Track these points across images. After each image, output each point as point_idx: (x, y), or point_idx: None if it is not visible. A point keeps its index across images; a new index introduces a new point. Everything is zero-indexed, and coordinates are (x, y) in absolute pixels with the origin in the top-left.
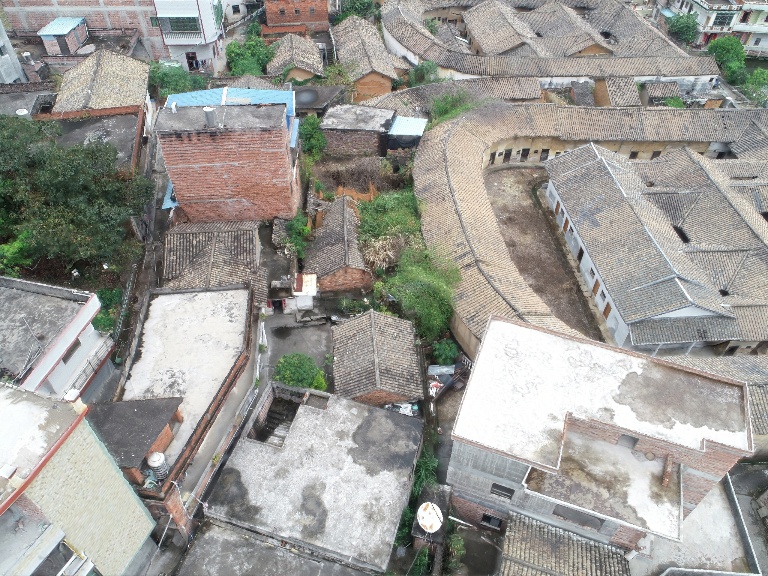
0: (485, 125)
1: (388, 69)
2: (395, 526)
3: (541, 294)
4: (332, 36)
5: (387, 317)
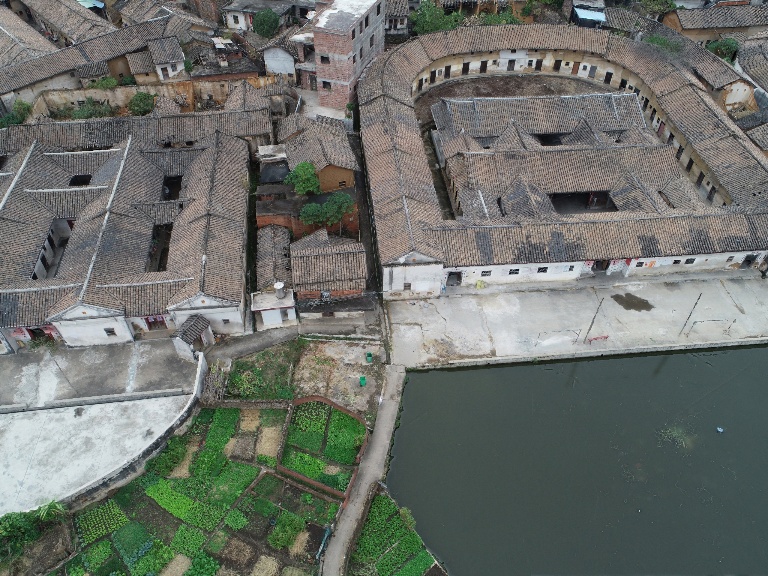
0: (631, 53)
1: (695, 22)
2: (306, 3)
3: (476, 95)
4: (732, 1)
5: (407, 5)
